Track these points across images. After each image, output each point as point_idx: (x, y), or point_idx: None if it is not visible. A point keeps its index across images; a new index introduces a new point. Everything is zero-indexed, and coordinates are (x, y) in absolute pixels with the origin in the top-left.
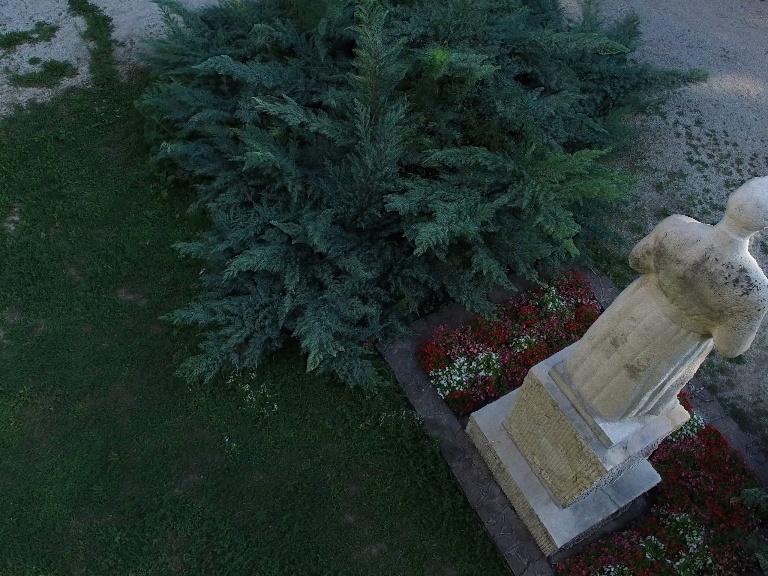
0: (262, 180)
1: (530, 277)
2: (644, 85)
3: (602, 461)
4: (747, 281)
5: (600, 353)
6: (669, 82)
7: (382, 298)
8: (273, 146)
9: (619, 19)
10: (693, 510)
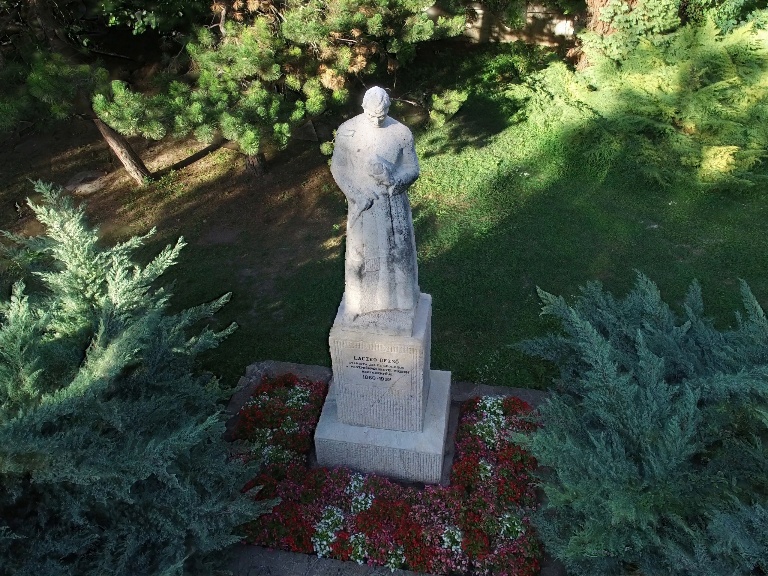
0: None
1: None
2: None
3: None
4: None
5: None
6: None
7: None
8: None
9: None
10: None
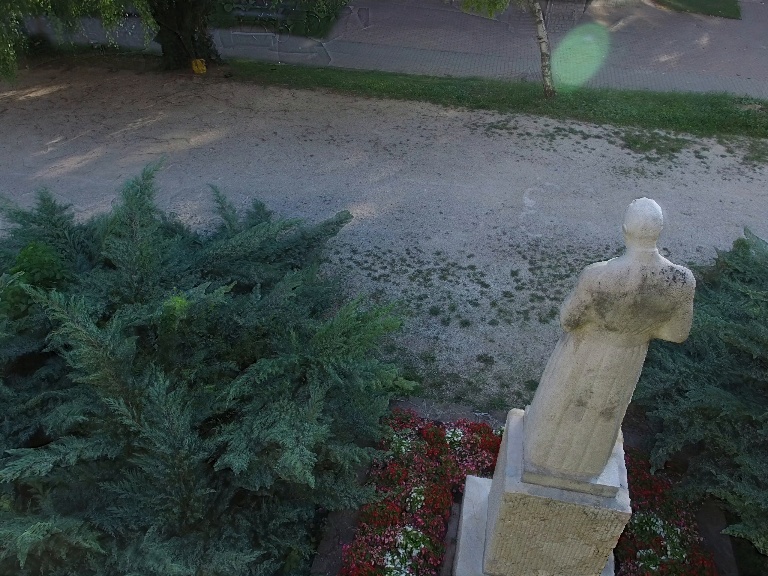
0: (26, 568)
1: (388, 435)
2: (315, 243)
3: (621, 510)
4: (679, 274)
5: (569, 423)
6: (331, 231)
7: (270, 571)
8: (21, 518)
9: (249, 210)
10: (636, 506)
